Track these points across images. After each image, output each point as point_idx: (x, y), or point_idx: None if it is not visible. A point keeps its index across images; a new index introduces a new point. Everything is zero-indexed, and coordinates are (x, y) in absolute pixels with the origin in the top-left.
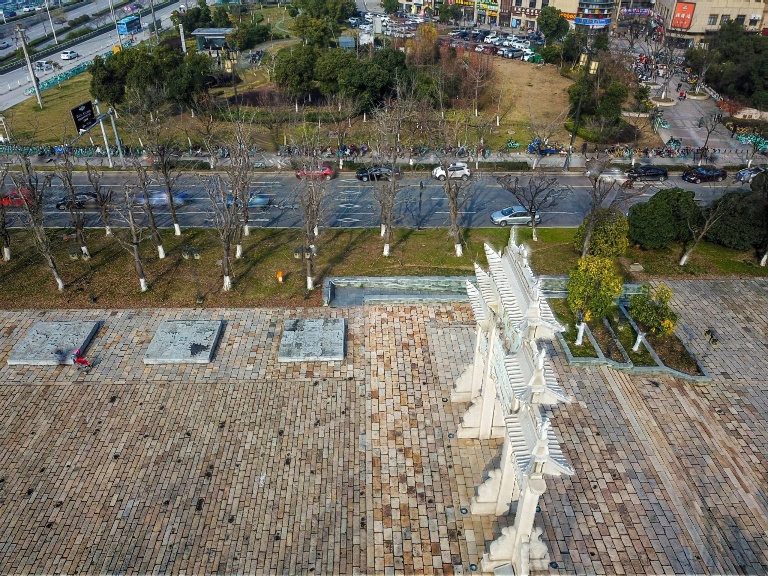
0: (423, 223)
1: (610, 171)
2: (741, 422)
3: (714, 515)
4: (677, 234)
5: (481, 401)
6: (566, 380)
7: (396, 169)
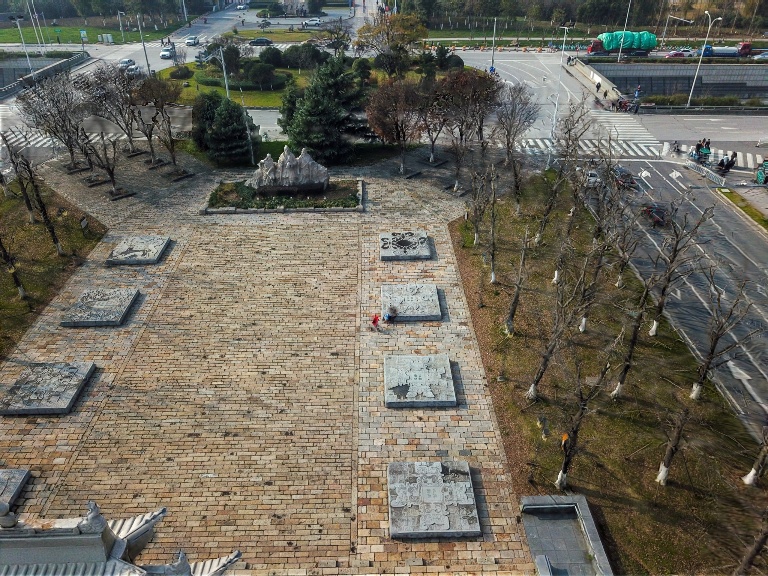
0: None
1: None
2: None
3: None
4: None
5: None
6: None
7: None
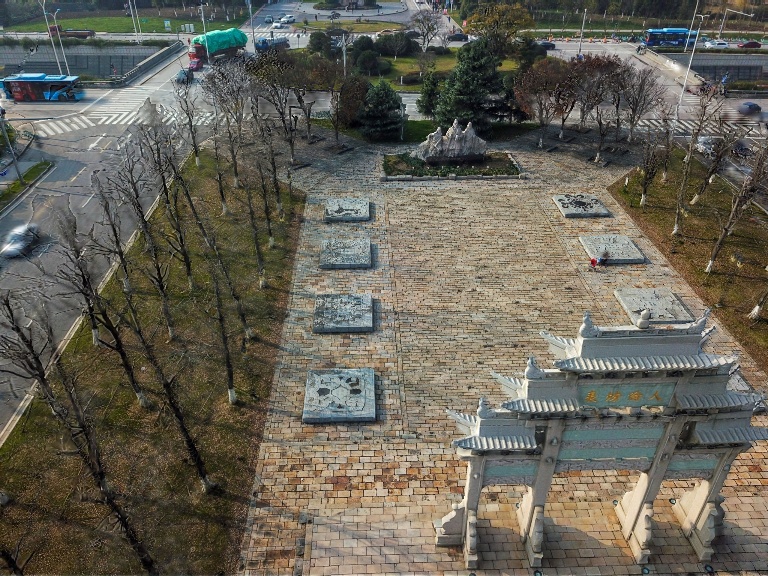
0: None
1: None
2: None
3: None
4: None
5: None
6: None
7: None
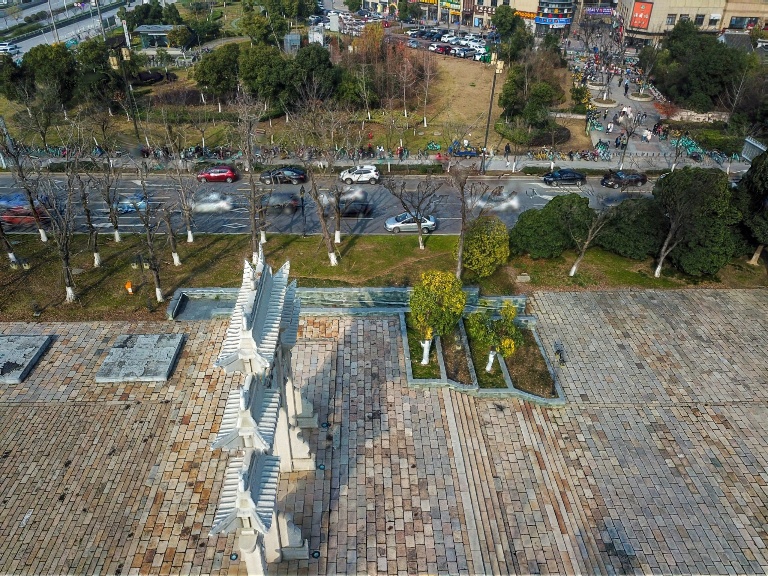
0: (314, 229)
1: (524, 175)
2: (586, 450)
3: (518, 560)
4: (571, 243)
5: None
6: (399, 404)
7: (301, 172)
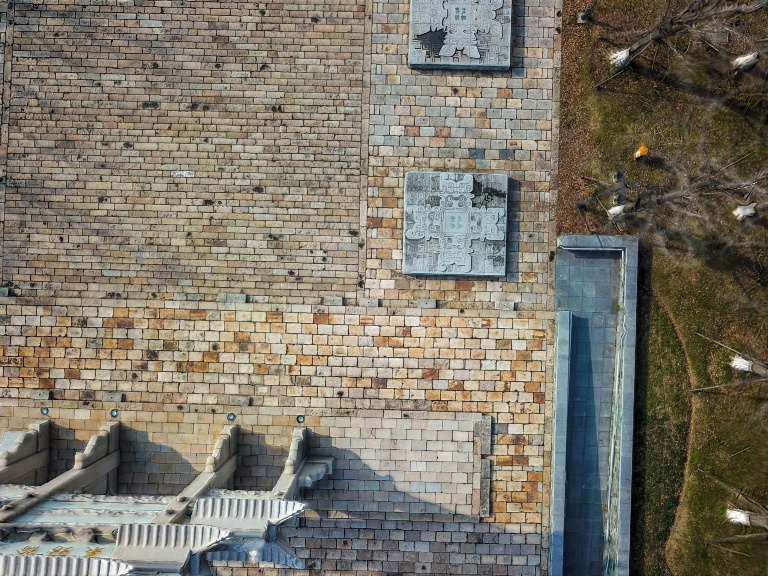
0: None
1: None
2: None
3: None
4: None
5: (205, 470)
6: None
7: None
